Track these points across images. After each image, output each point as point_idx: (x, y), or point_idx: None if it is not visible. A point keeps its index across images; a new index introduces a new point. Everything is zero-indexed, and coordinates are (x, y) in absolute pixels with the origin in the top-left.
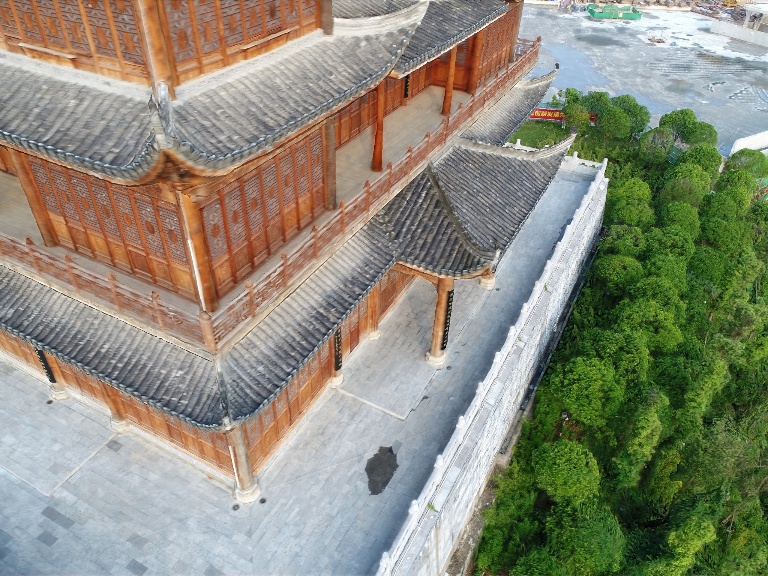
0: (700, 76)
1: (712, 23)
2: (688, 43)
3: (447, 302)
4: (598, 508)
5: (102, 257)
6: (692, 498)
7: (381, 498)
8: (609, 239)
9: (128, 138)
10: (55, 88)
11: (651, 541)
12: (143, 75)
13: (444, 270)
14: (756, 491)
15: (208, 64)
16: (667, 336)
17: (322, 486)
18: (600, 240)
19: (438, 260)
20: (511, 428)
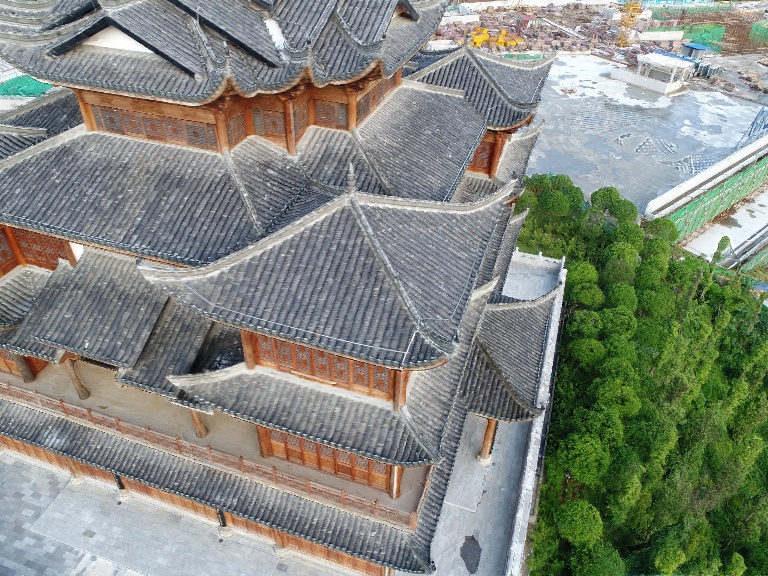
0: (610, 129)
1: (611, 69)
2: (594, 92)
3: (495, 426)
4: (605, 546)
5: (310, 464)
6: (665, 529)
7: (478, 575)
8: (575, 324)
9: (385, 436)
10: (321, 398)
11: (641, 562)
12: (386, 396)
13: (503, 418)
14: (703, 512)
15: (409, 374)
16: (631, 407)
17: (436, 574)
18: (564, 316)
19: (496, 409)
20: (533, 492)
